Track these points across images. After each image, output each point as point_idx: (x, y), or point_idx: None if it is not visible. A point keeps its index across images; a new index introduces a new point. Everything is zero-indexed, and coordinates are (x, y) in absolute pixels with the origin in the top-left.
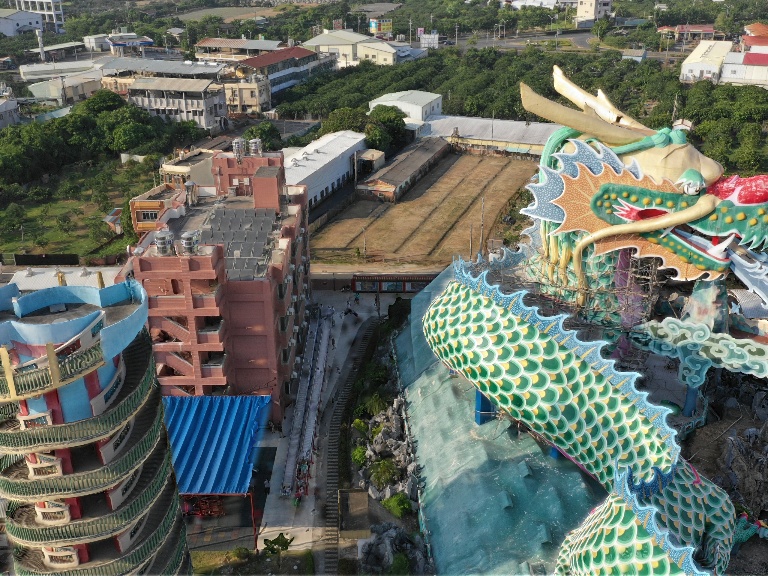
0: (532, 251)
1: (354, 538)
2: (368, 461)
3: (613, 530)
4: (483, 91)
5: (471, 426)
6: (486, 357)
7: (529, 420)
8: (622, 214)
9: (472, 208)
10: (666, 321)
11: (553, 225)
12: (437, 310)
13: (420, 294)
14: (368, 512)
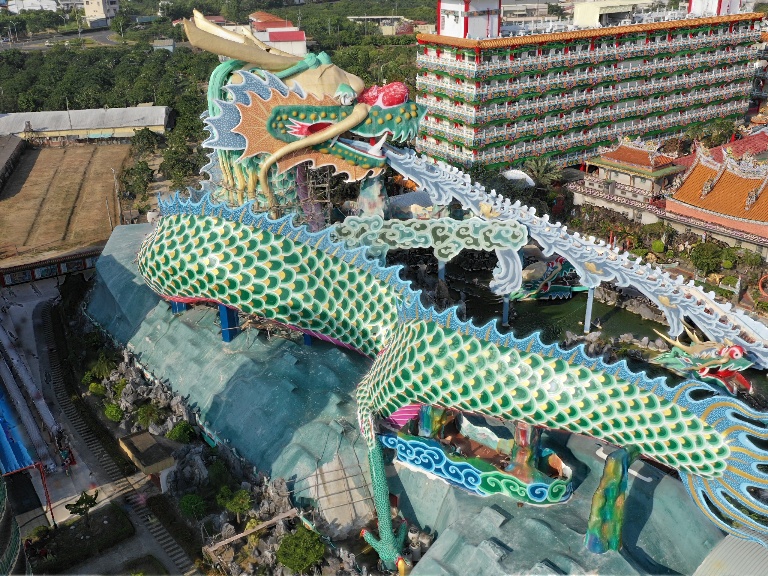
0: (214, 186)
1: (159, 470)
2: (125, 414)
3: (423, 341)
4: (31, 88)
5: (221, 346)
6: (232, 269)
7: (285, 314)
8: (295, 132)
9: (83, 193)
10: (347, 220)
11: (235, 154)
12: (162, 245)
13: (101, 259)
14: (160, 446)
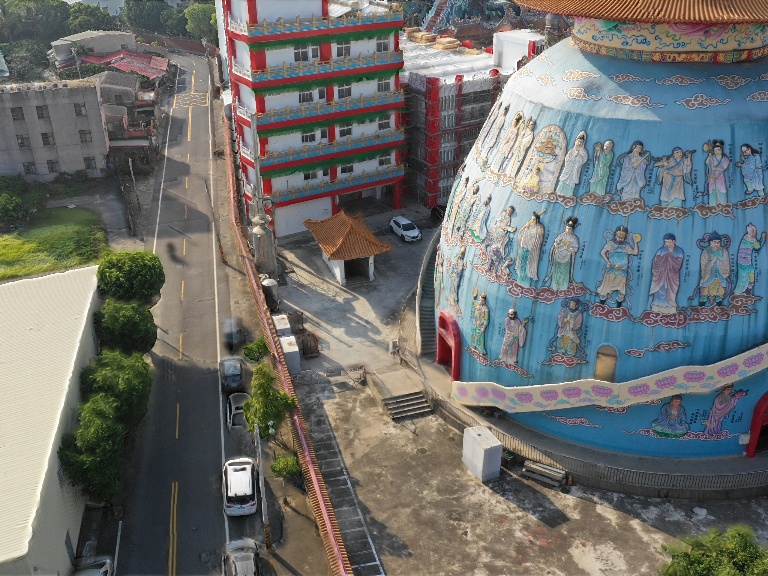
0: None
1: None
2: None
3: None
4: None
5: None
6: None
7: None
8: None
9: None
10: None
11: None
12: None
13: None
14: None
